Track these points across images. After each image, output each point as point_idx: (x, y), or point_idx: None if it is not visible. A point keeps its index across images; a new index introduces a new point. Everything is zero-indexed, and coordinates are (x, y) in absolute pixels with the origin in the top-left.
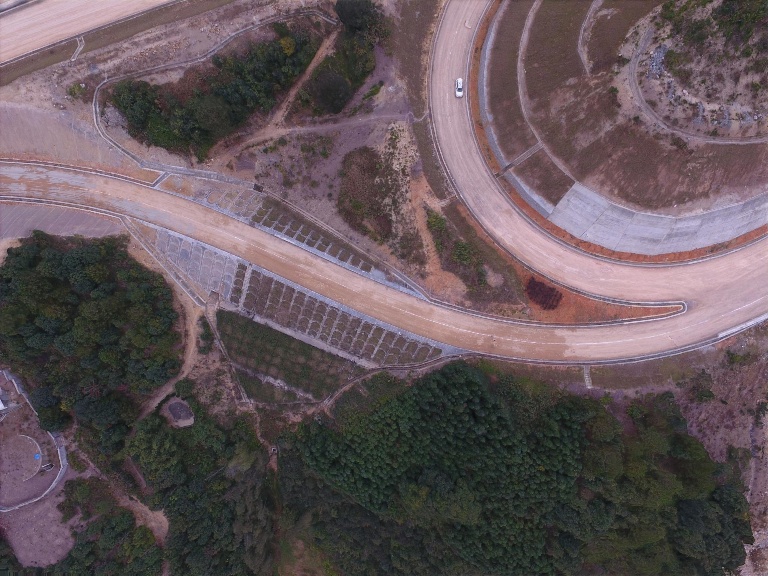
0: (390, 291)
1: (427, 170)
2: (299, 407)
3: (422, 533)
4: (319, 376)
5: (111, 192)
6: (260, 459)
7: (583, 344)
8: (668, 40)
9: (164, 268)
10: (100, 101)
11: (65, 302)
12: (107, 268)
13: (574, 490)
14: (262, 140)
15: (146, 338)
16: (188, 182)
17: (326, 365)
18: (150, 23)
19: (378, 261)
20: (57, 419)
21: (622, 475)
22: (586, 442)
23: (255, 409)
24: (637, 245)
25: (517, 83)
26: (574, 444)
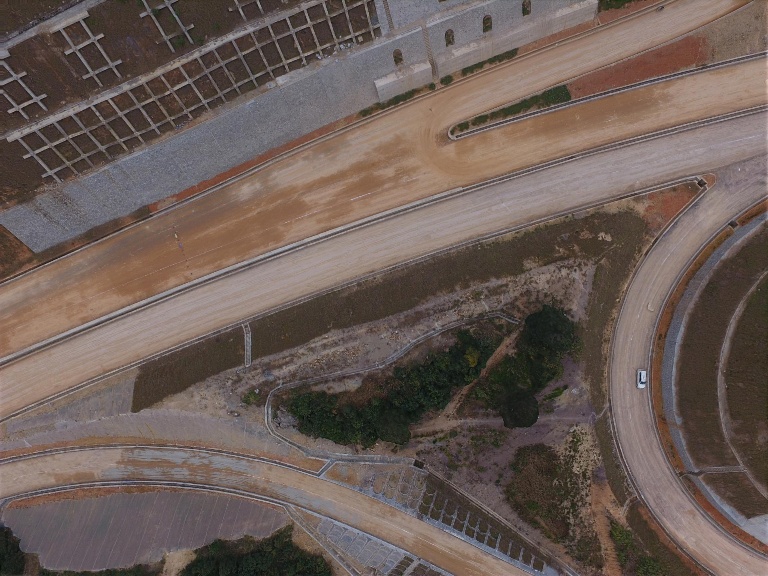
0: None
1: (609, 474)
2: None
3: None
4: None
5: (275, 479)
6: None
7: None
8: None
9: (323, 547)
10: (273, 405)
11: None
12: (277, 570)
13: None
14: (432, 431)
15: None
16: (353, 470)
17: None
18: (322, 317)
19: (549, 555)
20: None
21: None
22: None
23: None
24: None
25: (717, 399)
26: None
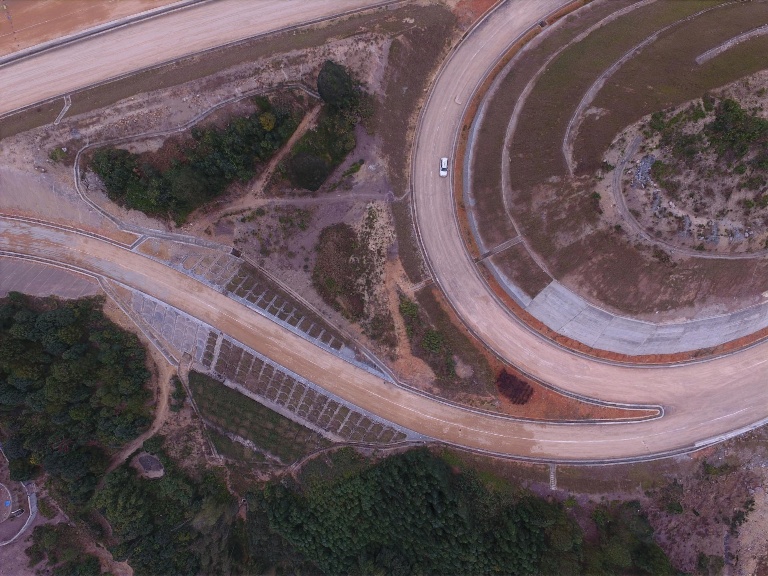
0: (358, 371)
1: (403, 252)
2: (267, 467)
3: None
4: (286, 442)
5: (90, 251)
6: (227, 513)
7: (552, 441)
8: (656, 150)
9: (139, 327)
10: (81, 165)
11: (37, 362)
12: (80, 330)
13: None
14: (240, 209)
15: (116, 397)
16: (165, 246)
17: (293, 433)
18: (135, 87)
19: (349, 338)
20: (27, 470)
21: None
22: (544, 547)
23: (225, 464)
24: (616, 345)
25: (501, 172)
26: (531, 548)
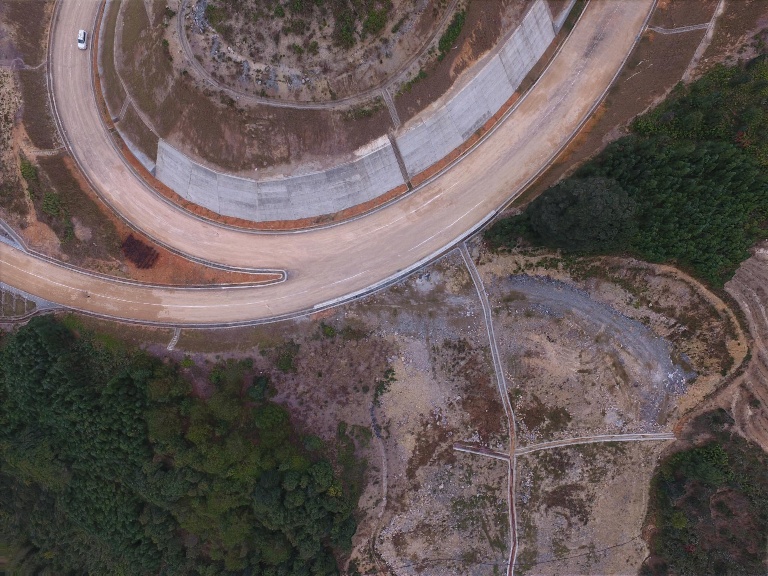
0: None
1: (30, 118)
2: None
3: (52, 496)
4: None
5: None
6: None
7: (179, 306)
8: None
9: None
10: None
11: None
12: None
13: (141, 452)
14: None
15: None
16: None
17: None
18: None
19: None
20: None
21: (188, 439)
22: None
23: None
24: (237, 209)
25: (114, 35)
26: (135, 404)
